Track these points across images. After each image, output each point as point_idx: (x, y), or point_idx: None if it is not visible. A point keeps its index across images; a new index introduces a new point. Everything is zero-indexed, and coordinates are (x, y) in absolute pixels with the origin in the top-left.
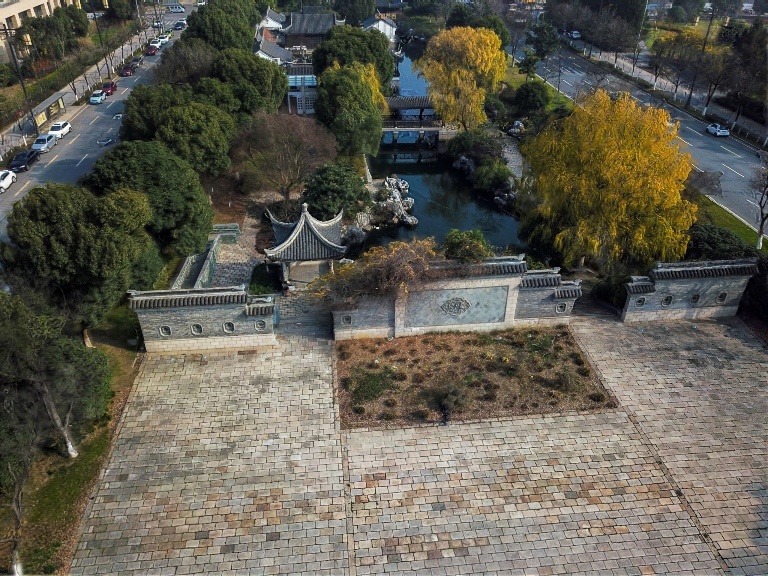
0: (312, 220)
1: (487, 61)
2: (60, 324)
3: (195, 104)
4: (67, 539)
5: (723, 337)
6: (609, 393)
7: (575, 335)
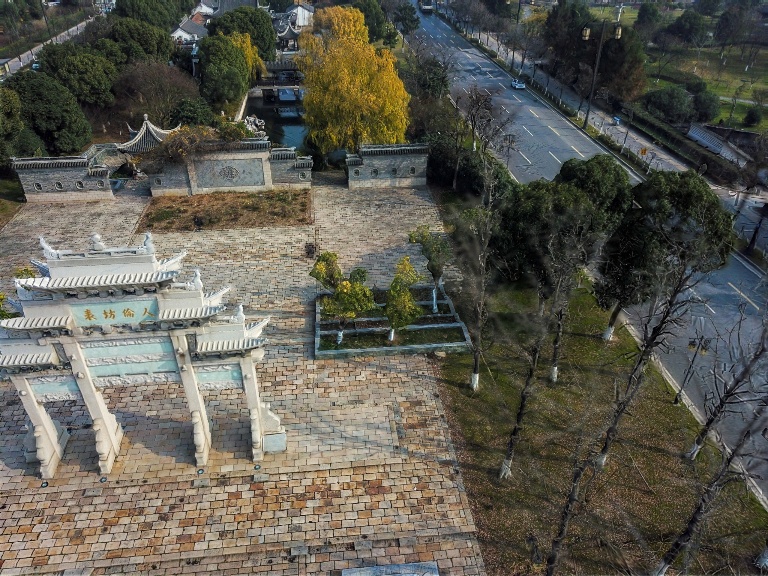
0: (153, 127)
1: (349, 33)
2: None
3: (86, 54)
4: None
5: (408, 195)
6: (312, 218)
7: (312, 194)
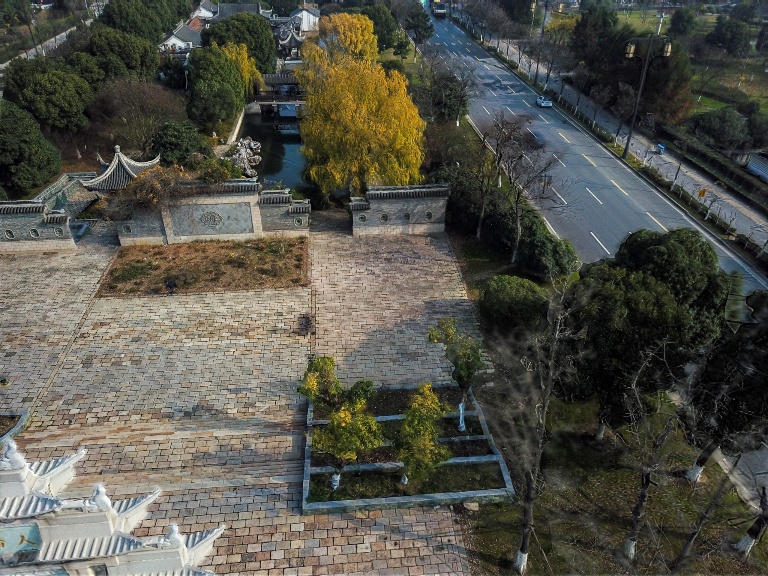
0: (126, 160)
1: (356, 43)
2: None
3: (55, 72)
4: None
5: (423, 245)
6: (308, 278)
7: (310, 243)
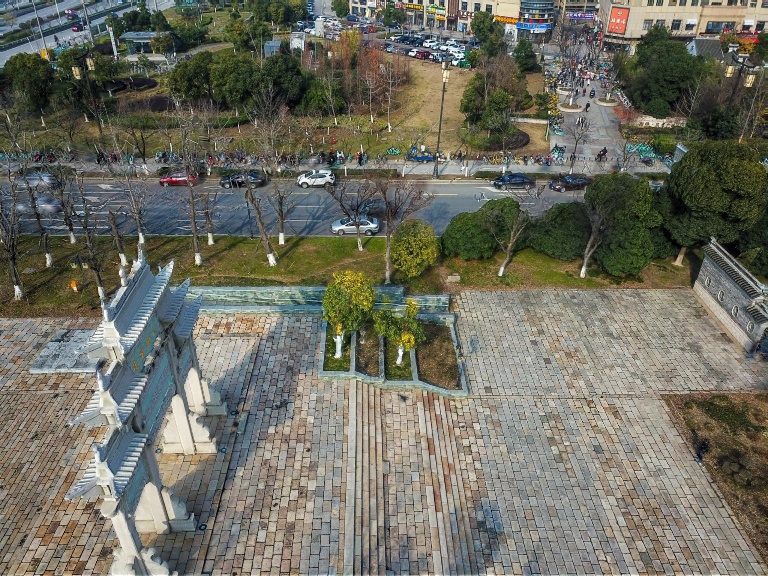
0: None
1: None
2: (656, 221)
3: None
4: (526, 286)
5: None
6: None
7: None
